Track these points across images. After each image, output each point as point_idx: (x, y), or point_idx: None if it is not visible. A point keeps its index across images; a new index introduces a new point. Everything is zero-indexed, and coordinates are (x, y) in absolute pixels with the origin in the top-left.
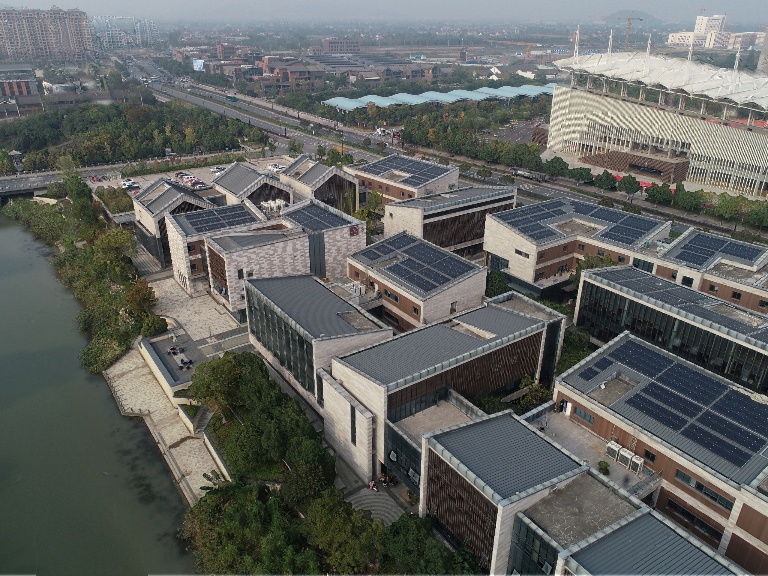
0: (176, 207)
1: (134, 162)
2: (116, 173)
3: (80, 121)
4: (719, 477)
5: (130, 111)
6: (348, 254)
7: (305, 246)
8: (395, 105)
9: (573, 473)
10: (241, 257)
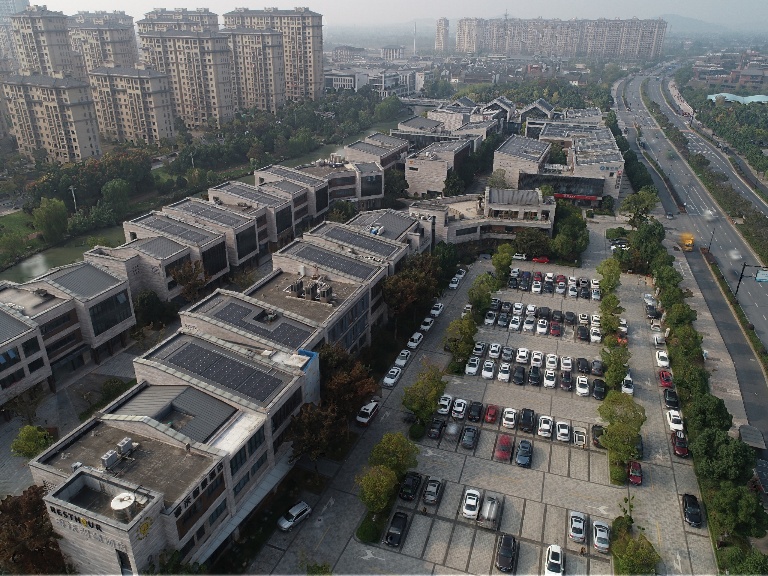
0: (453, 105)
1: None
2: None
3: (526, 86)
4: (416, 153)
5: (540, 80)
6: (467, 122)
7: (461, 119)
8: (757, 103)
9: (391, 144)
10: (434, 115)
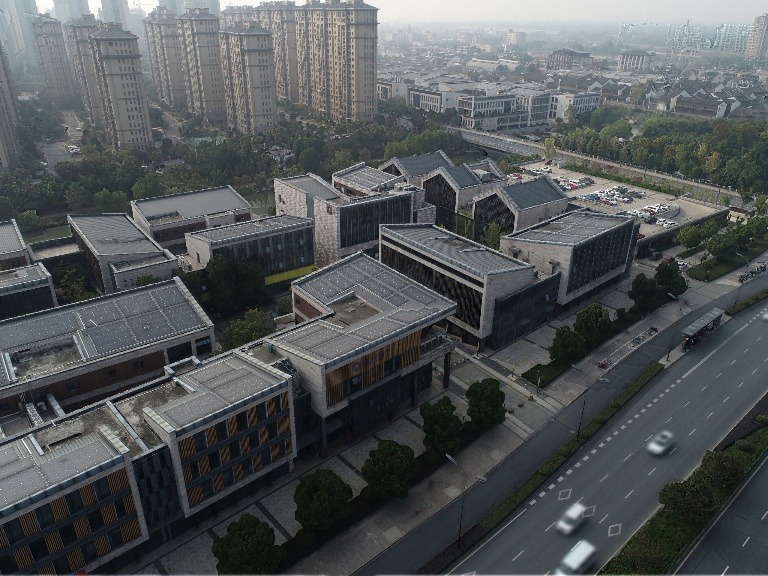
0: (389, 166)
1: (635, 168)
2: (562, 162)
3: None
4: None
5: (718, 125)
6: None
7: (305, 201)
8: None
9: None
10: None
